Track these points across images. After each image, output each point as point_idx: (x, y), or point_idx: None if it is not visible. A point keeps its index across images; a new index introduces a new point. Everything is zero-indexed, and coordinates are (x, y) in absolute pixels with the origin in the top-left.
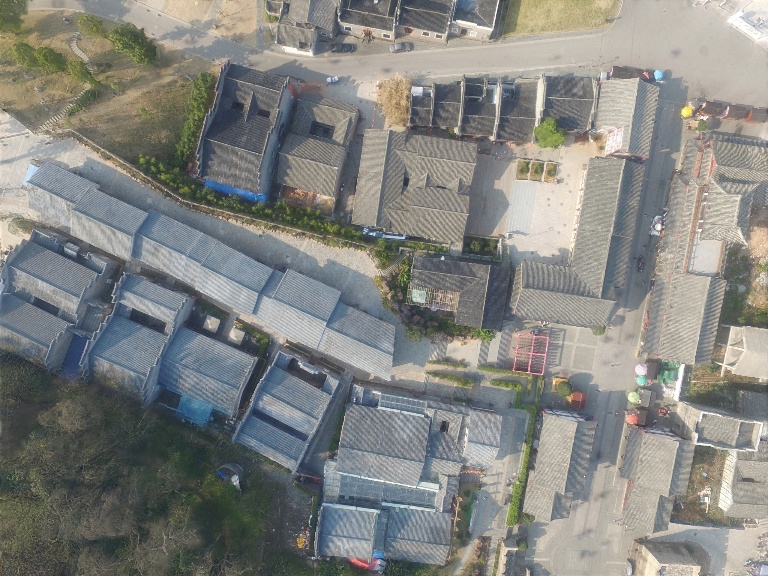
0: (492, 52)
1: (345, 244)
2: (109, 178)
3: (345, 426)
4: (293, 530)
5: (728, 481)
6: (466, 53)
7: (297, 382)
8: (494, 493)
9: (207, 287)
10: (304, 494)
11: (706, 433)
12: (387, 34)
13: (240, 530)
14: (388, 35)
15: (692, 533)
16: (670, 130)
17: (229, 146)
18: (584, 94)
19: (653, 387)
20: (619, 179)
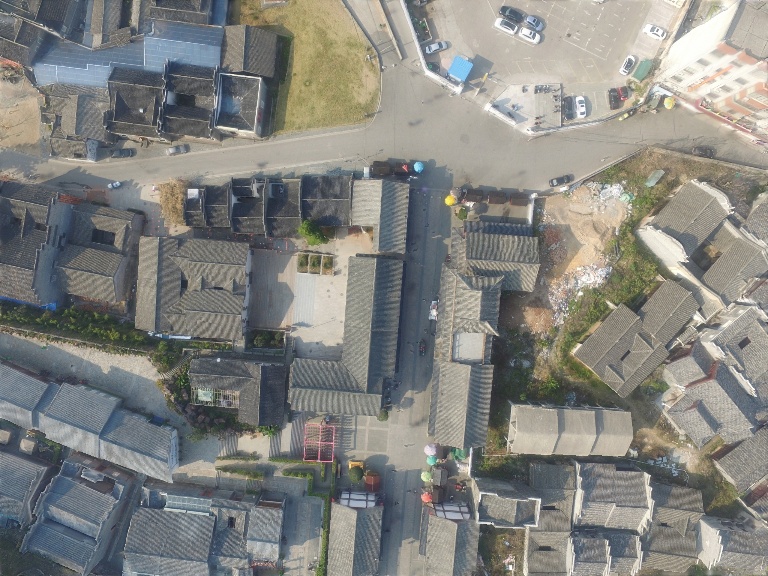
0: (265, 150)
1: (124, 351)
2: None
3: (130, 530)
4: None
5: None
6: (240, 152)
7: (83, 490)
8: None
9: None
10: None
11: (490, 511)
12: (160, 139)
13: None
14: (162, 140)
15: None
16: (440, 217)
17: (3, 264)
18: (340, 194)
19: (448, 464)
20: (373, 278)
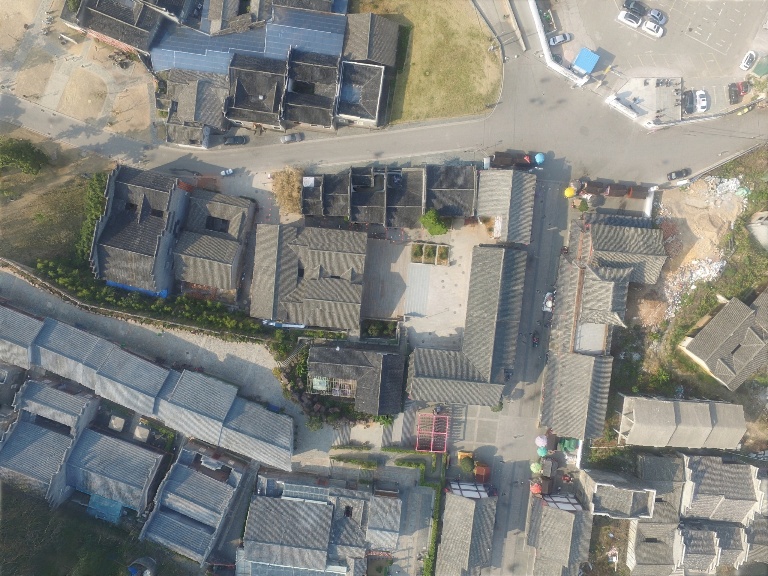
0: (381, 139)
1: (242, 339)
2: (8, 284)
3: (249, 519)
4: None
5: (632, 542)
6: (356, 141)
7: (201, 478)
8: (406, 567)
9: (106, 392)
10: None
11: (603, 502)
12: (276, 127)
13: None
14: (278, 127)
15: None
16: (556, 209)
17: (122, 250)
18: (465, 184)
19: (556, 455)
20: (500, 268)
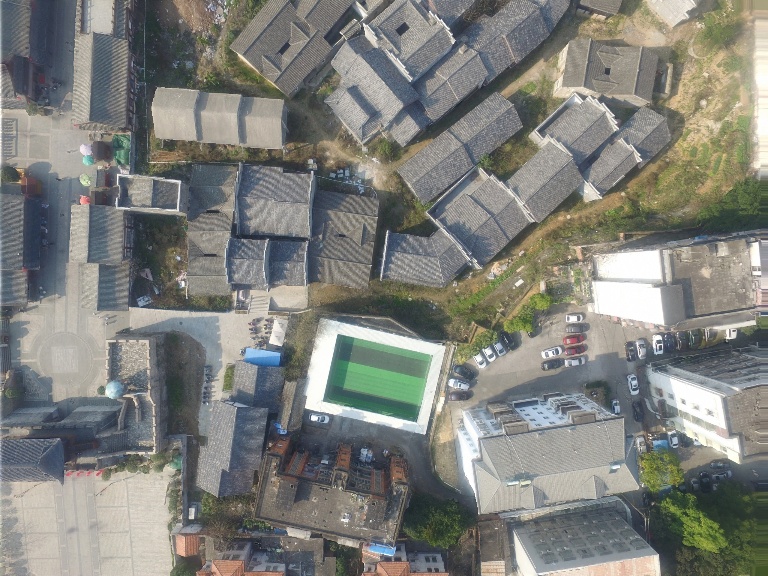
0: None
1: None
2: None
3: None
4: None
5: None
6: None
7: None
8: None
9: None
10: None
11: (133, 199)
12: None
13: None
14: None
15: (177, 322)
16: None
17: None
18: None
19: (112, 171)
20: None
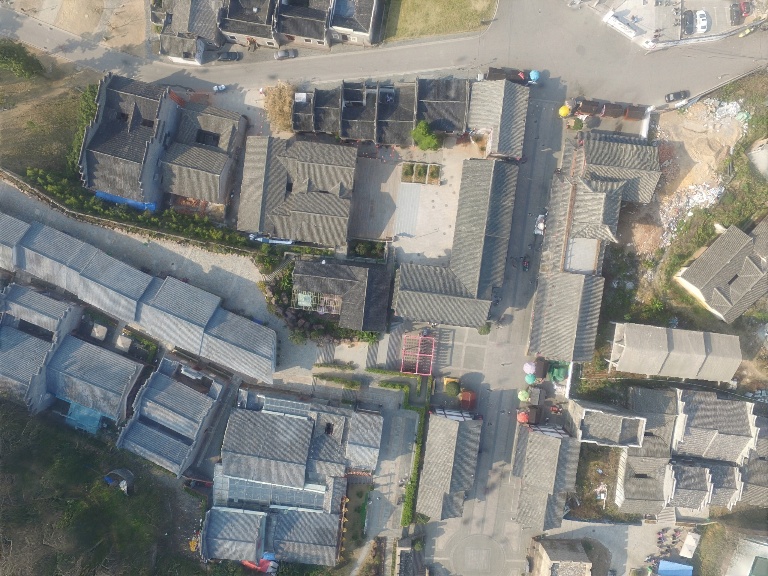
0: (374, 57)
1: (228, 250)
2: None
3: (228, 430)
4: (185, 534)
5: (622, 477)
6: (349, 58)
7: (181, 388)
8: (387, 493)
9: (89, 296)
10: (194, 498)
11: (591, 430)
12: (270, 42)
13: (129, 535)
14: (271, 43)
15: (590, 530)
16: (550, 129)
17: (111, 156)
18: (457, 96)
19: (544, 385)
20: (490, 180)
